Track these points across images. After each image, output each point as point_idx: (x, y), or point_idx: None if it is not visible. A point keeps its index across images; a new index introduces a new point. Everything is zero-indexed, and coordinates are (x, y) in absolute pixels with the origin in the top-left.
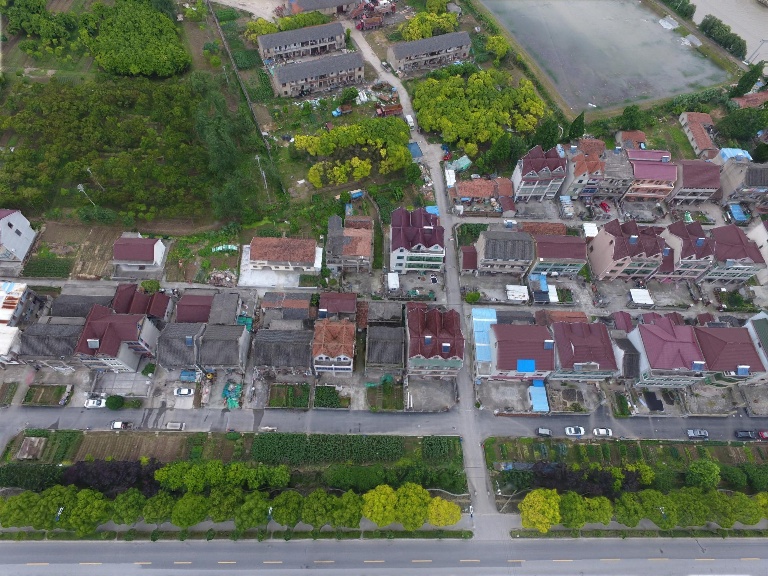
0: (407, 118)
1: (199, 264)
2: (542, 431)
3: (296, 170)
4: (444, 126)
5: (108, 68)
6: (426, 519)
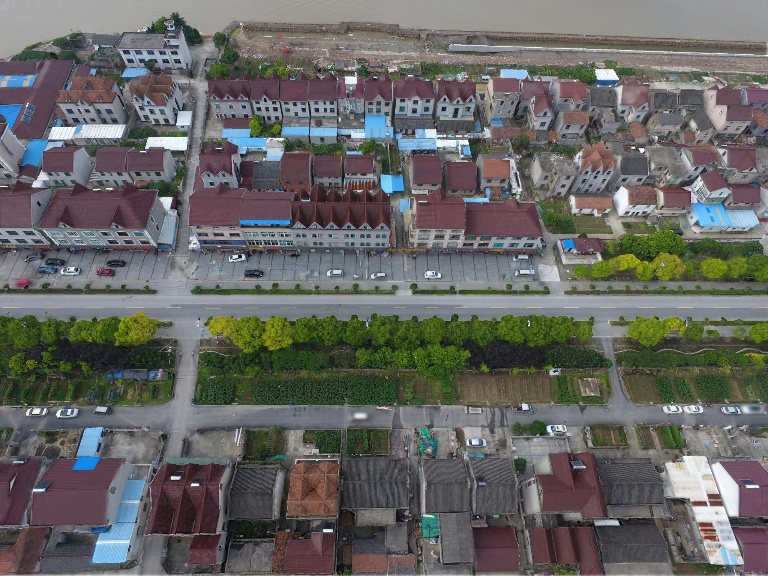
0: None
1: None
2: (104, 409)
3: None
4: None
5: None
6: None
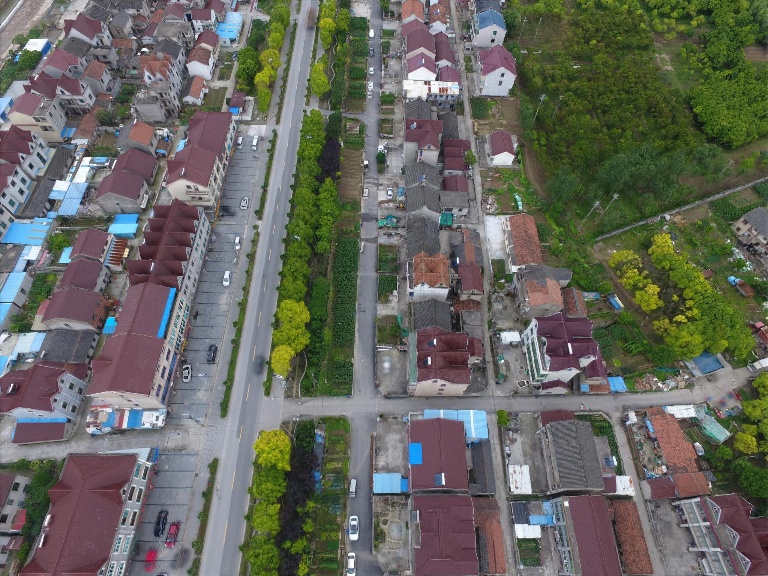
0: (765, 359)
1: (500, 188)
2: (353, 482)
3: (630, 248)
4: (767, 399)
5: (690, 94)
6: (279, 345)
